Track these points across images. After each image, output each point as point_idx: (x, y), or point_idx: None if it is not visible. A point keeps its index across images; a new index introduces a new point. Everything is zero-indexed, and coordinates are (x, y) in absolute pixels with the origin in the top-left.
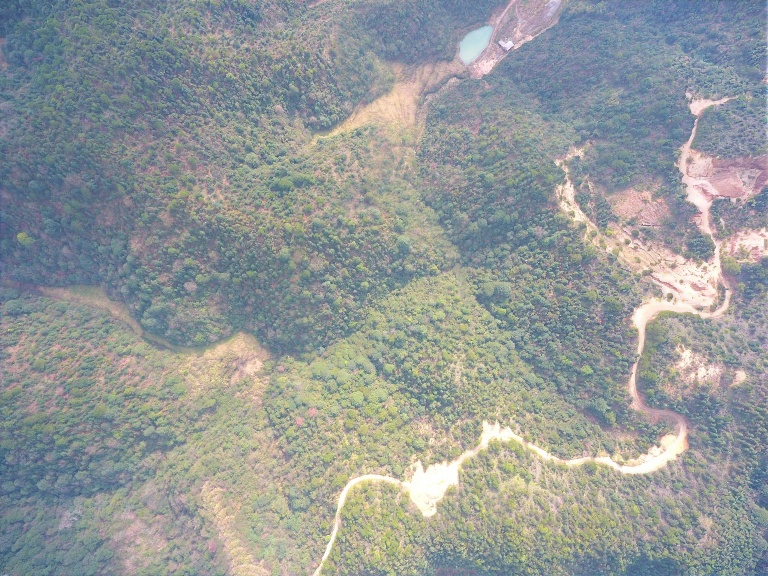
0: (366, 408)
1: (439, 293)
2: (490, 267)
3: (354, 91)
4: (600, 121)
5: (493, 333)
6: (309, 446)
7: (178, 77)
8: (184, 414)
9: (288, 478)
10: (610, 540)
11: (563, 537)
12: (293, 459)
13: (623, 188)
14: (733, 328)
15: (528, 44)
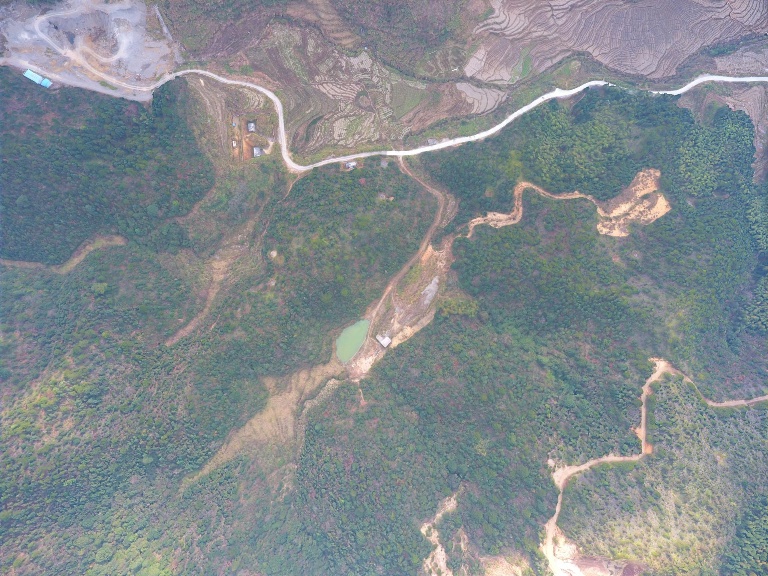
0: None
1: None
2: None
3: (220, 429)
4: (471, 466)
5: None
6: None
7: (7, 507)
8: None
9: None
10: None
11: None
12: None
13: (495, 555)
14: None
15: (403, 348)
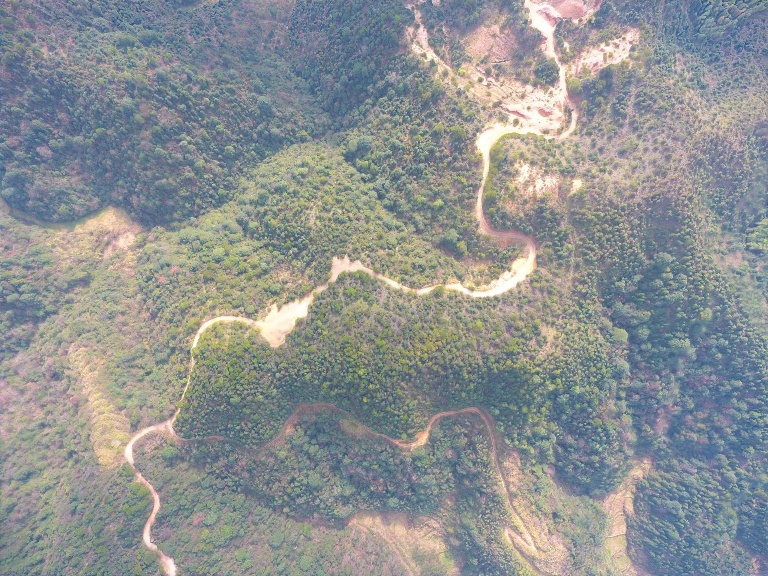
0: (226, 261)
1: (307, 156)
2: (356, 126)
3: None
4: None
5: (355, 184)
6: (170, 301)
7: None
8: (52, 284)
9: (153, 335)
10: (452, 353)
11: (401, 350)
12: (158, 317)
13: (474, 26)
14: (575, 144)
15: None
